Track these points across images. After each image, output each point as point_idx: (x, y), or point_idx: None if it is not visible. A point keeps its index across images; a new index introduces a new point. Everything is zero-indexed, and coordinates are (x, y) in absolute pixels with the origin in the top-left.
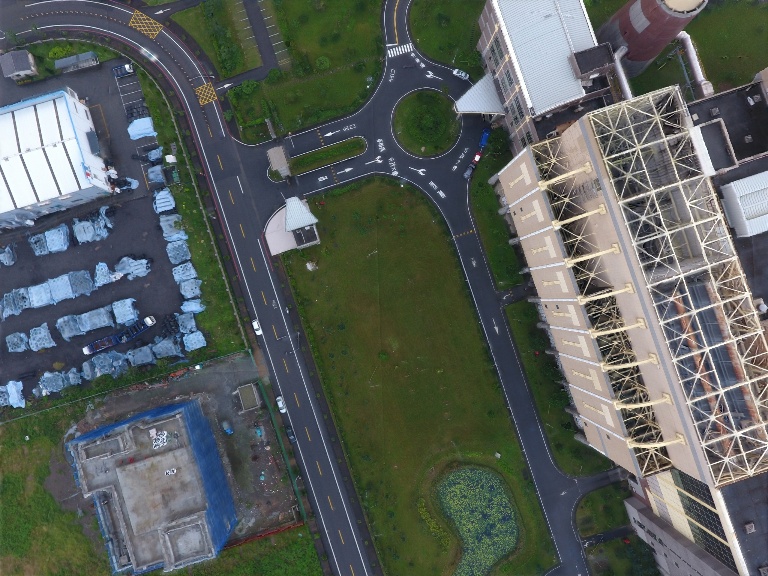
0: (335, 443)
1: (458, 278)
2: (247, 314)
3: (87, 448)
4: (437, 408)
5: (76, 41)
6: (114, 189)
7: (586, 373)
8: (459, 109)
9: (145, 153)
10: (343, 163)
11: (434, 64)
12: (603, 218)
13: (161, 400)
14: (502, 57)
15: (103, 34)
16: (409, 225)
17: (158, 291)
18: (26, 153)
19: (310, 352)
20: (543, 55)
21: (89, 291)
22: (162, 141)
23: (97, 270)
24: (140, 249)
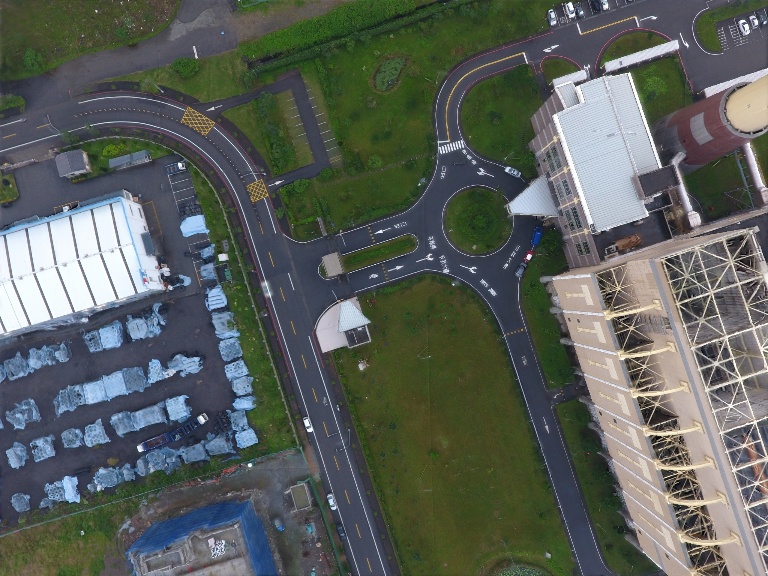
0: (385, 540)
1: (509, 377)
2: (298, 411)
3: (149, 561)
4: (487, 507)
5: (129, 139)
6: (167, 287)
7: (645, 492)
8: (512, 211)
9: (197, 250)
10: (394, 261)
11: (485, 161)
12: (671, 354)
13: (213, 496)
14: (559, 166)
15: (155, 131)
16: (460, 323)
17: (210, 388)
18: (84, 259)
19: (360, 449)
20: (605, 174)
21: (142, 388)
22: (214, 238)
23: (151, 368)
24: (192, 346)
